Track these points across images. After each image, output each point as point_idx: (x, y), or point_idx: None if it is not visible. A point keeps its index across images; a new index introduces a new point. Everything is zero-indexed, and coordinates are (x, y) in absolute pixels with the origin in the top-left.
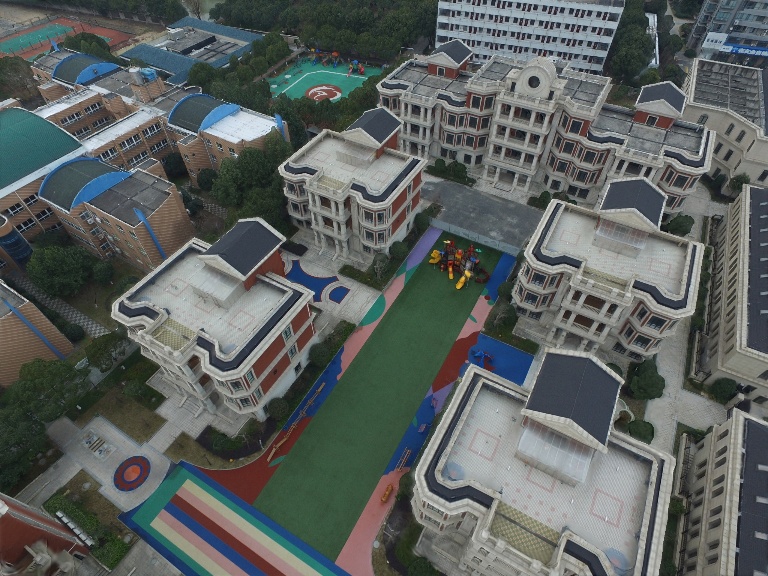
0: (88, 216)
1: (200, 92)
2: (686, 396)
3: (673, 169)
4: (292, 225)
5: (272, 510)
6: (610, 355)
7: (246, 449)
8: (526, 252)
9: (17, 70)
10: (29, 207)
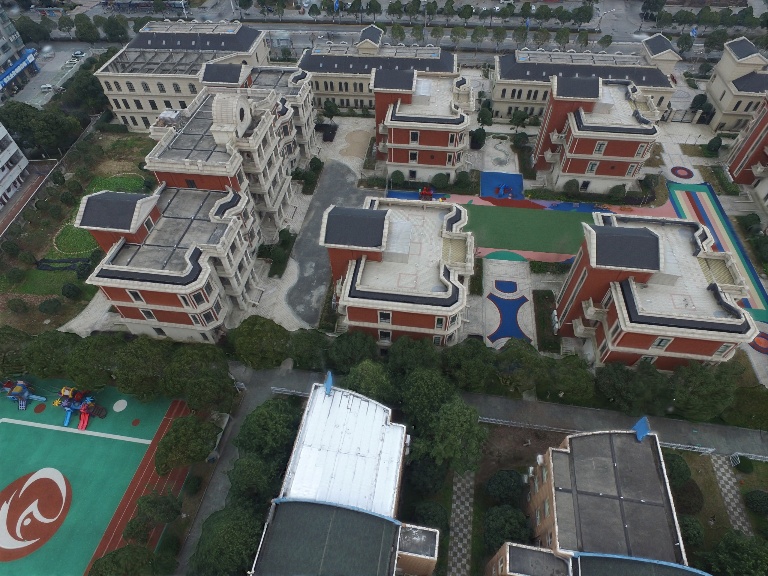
0: None
1: None
2: None
3: None
4: None
5: None
6: None
7: None
8: (459, 127)
9: None
10: None
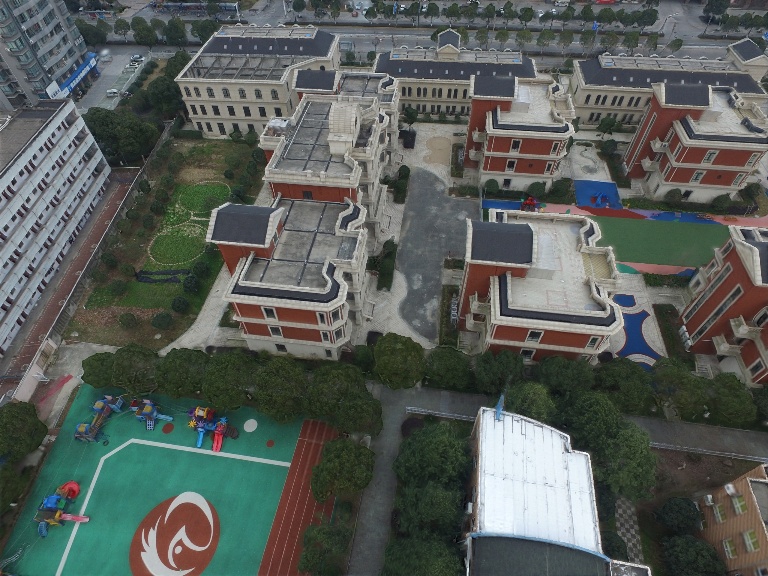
0: None
1: None
2: None
3: None
4: None
5: None
6: None
7: None
8: (565, 136)
9: None
10: None
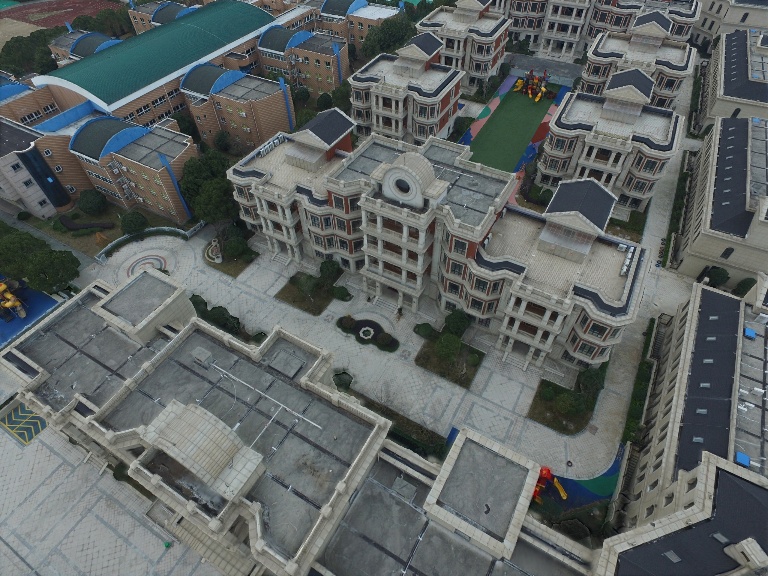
0: (291, 59)
1: None
2: (688, 140)
3: (675, 22)
4: None
5: None
6: None
7: None
8: (588, 54)
9: None
10: None
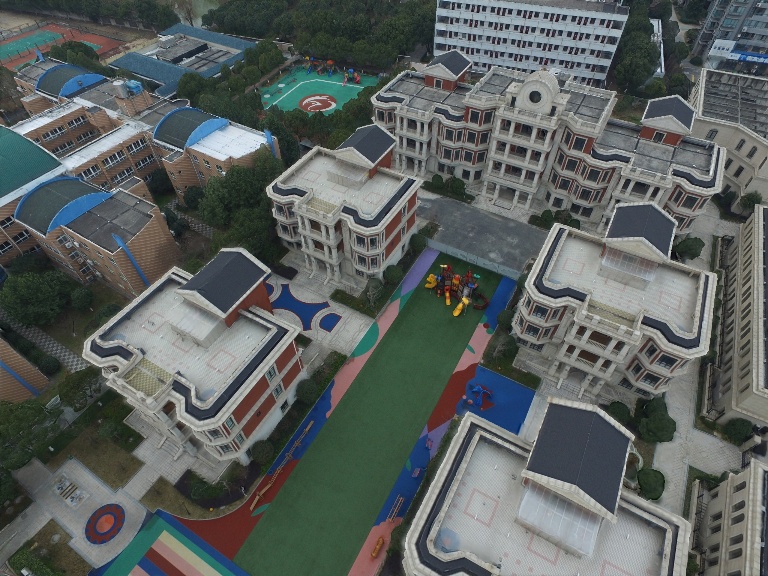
0: (66, 240)
1: (188, 105)
2: (698, 436)
3: (682, 189)
4: (282, 246)
5: (254, 566)
6: (616, 390)
7: (227, 497)
8: (527, 283)
9: (1, 81)
10: (5, 230)
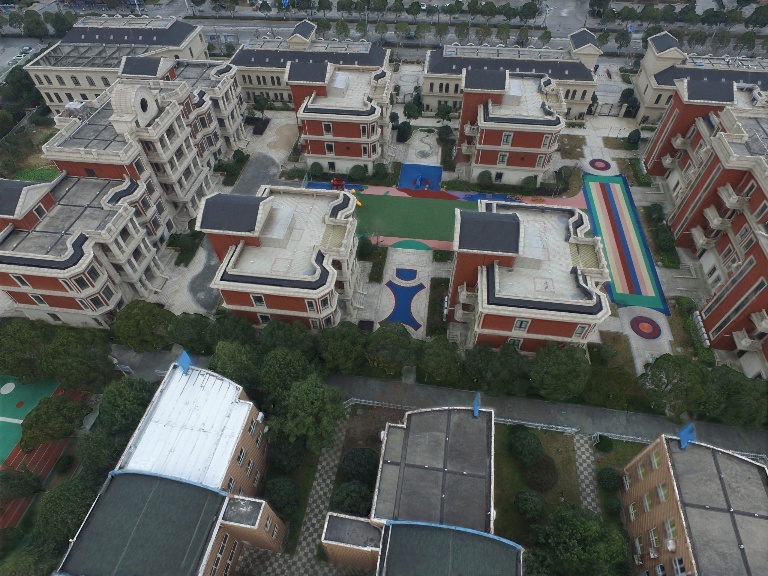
0: None
1: None
2: None
3: None
4: None
5: None
6: None
7: None
8: (368, 119)
9: None
10: None
